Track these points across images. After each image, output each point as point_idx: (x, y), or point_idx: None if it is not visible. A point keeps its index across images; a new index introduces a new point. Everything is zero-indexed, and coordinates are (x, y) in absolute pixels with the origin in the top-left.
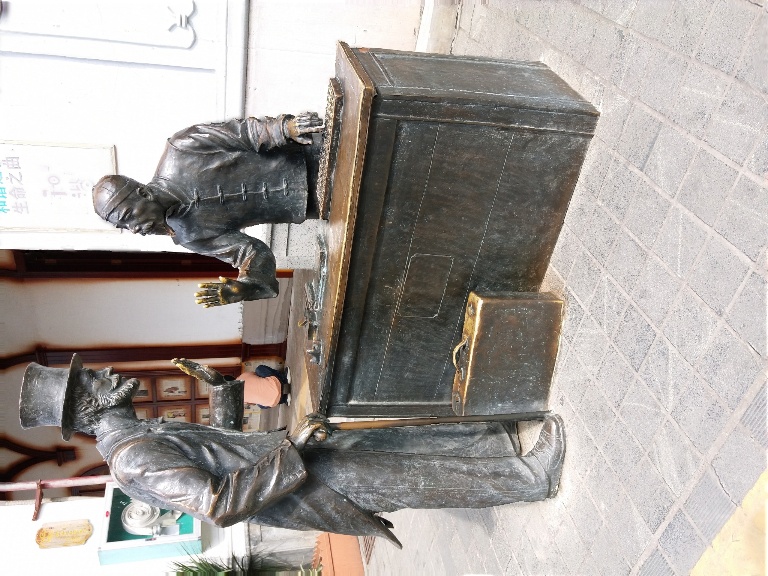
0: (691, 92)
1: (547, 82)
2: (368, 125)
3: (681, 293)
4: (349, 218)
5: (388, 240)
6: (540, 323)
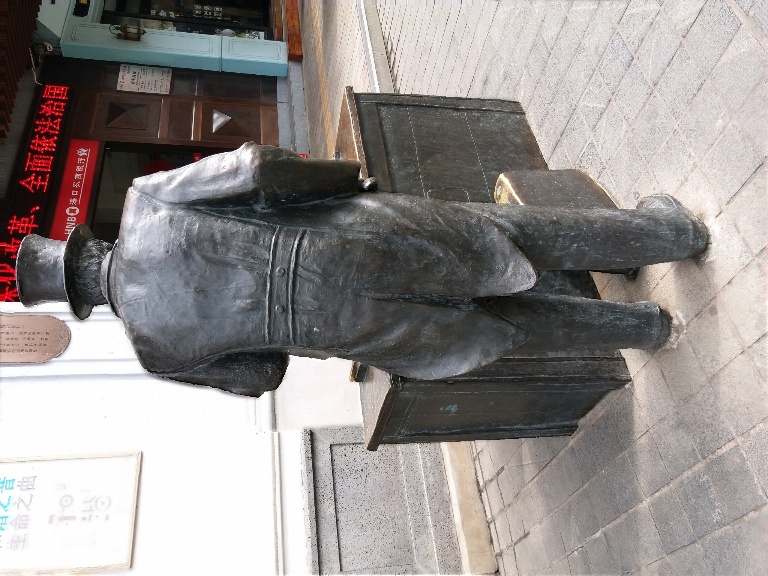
0: (539, 6)
1: None
2: (355, 102)
3: (604, 3)
4: (359, 158)
5: (400, 180)
6: (568, 177)
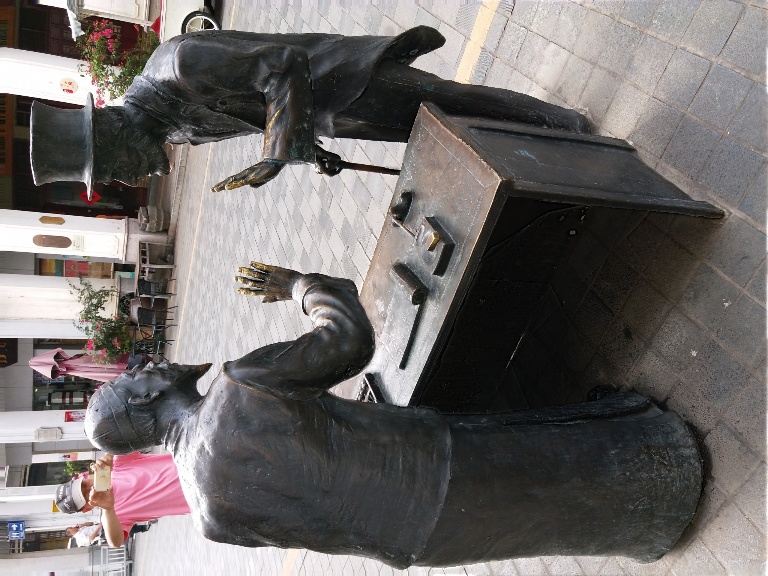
0: None
1: None
2: None
3: None
4: None
5: None
6: None
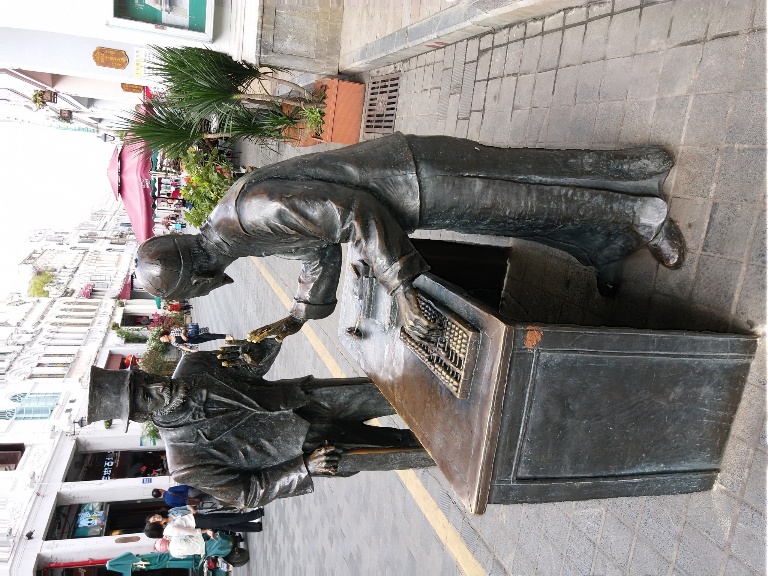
0: None
1: (714, 411)
2: None
3: None
4: None
5: None
6: None
